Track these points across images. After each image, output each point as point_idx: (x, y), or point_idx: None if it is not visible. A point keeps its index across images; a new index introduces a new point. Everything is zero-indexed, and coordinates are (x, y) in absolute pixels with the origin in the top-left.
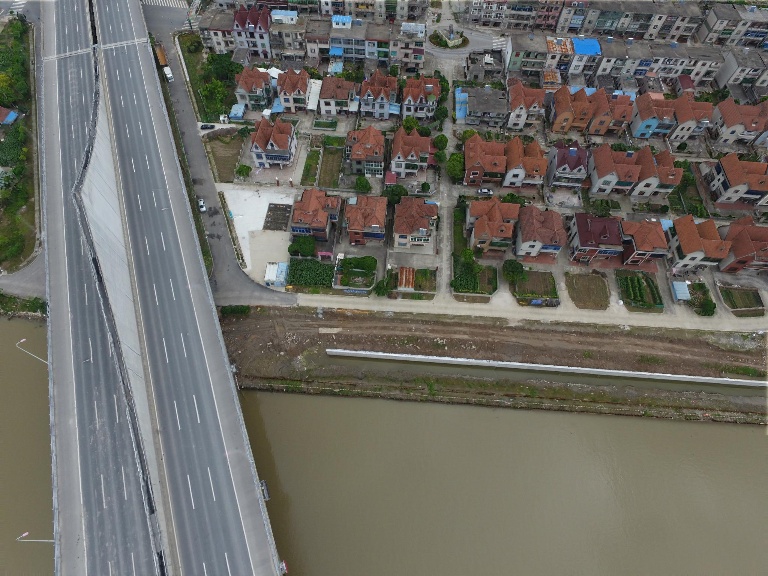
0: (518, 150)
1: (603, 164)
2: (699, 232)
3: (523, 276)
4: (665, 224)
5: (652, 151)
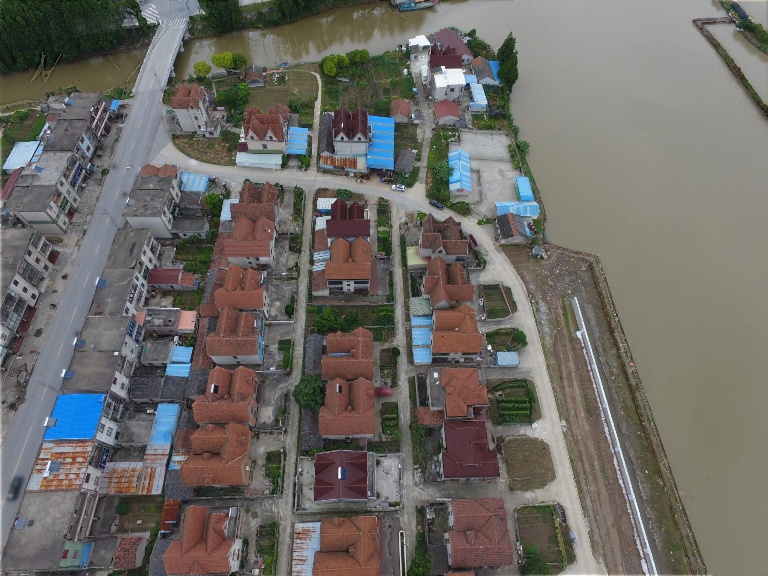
0: (346, 571)
1: (354, 427)
2: (447, 329)
3: (532, 554)
4: (422, 357)
5: (291, 345)
